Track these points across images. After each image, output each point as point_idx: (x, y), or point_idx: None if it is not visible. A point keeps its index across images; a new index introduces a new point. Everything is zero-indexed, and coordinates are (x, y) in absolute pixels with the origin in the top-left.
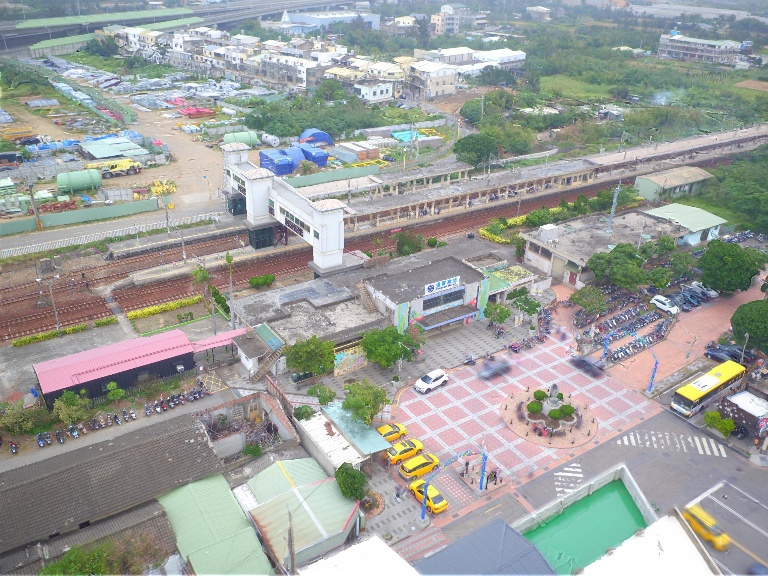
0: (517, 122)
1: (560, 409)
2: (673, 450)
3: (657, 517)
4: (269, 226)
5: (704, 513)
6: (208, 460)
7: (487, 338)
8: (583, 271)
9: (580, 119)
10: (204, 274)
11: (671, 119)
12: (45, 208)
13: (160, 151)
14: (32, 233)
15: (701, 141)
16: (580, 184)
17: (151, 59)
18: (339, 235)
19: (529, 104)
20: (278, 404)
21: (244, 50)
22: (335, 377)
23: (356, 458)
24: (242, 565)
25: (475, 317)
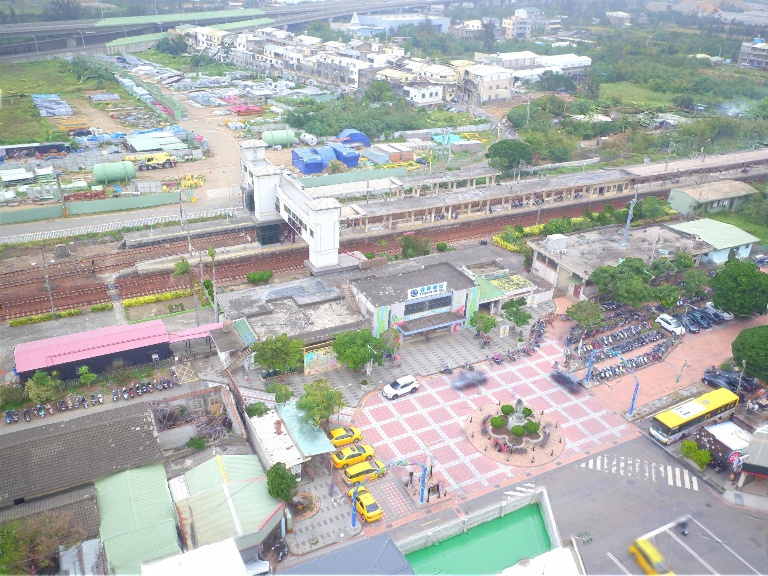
0: (565, 129)
1: (524, 426)
2: (640, 478)
3: None
4: (275, 223)
5: (656, 548)
6: (150, 449)
7: (472, 347)
8: (587, 284)
9: (630, 127)
10: (185, 266)
11: (725, 130)
12: (76, 196)
13: (197, 146)
14: (58, 220)
15: (756, 154)
16: (614, 194)
17: (216, 58)
18: (334, 235)
19: (582, 111)
20: (231, 399)
21: (301, 50)
22: (306, 376)
23: (296, 459)
24: (154, 555)
25: (464, 325)
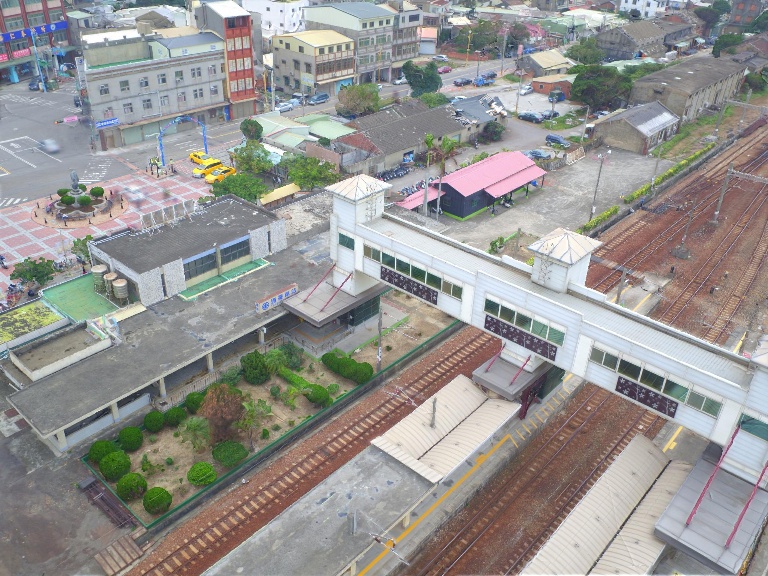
0: None
1: None
2: None
3: (84, 61)
4: None
5: None
6: None
7: None
8: None
9: None
10: None
11: None
12: None
13: None
14: None
15: None
16: None
17: None
18: None
19: None
20: None
21: None
22: None
23: None
24: None
25: None
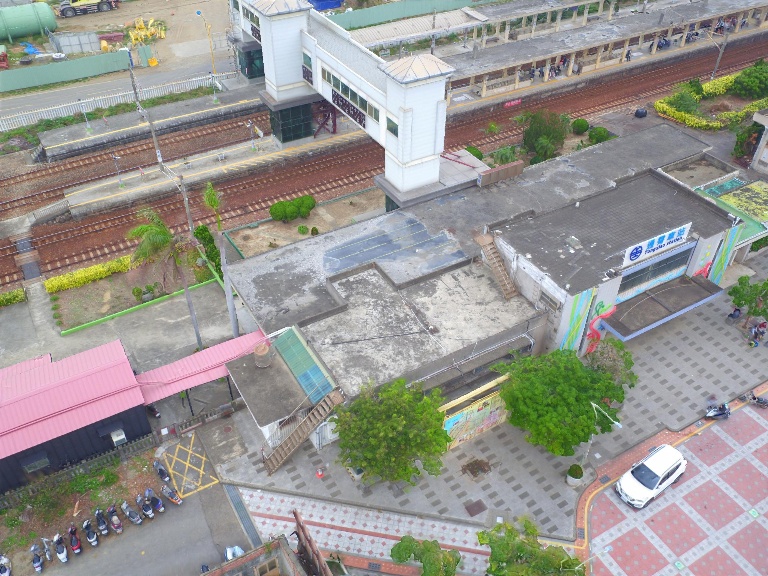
0: None
1: None
2: None
3: None
4: (304, 102)
5: None
6: None
7: (733, 345)
8: None
9: None
10: (158, 235)
11: None
12: None
13: None
14: None
15: None
16: None
17: None
18: (435, 128)
19: None
20: None
21: None
22: None
23: None
24: None
25: None
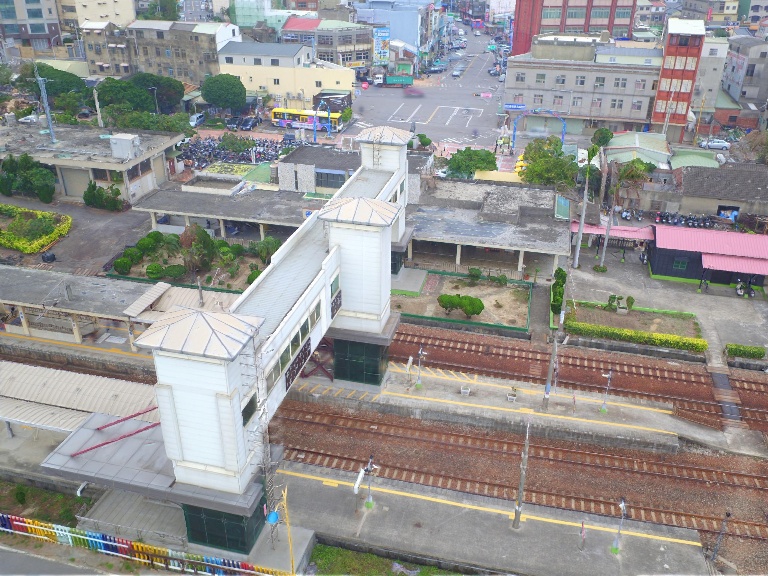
0: None
1: None
2: None
3: None
4: None
5: None
6: None
7: None
8: None
9: None
10: None
11: None
12: None
13: None
14: None
15: None
16: None
17: None
18: None
19: None
20: None
21: None
22: None
23: (582, 150)
24: None
25: None
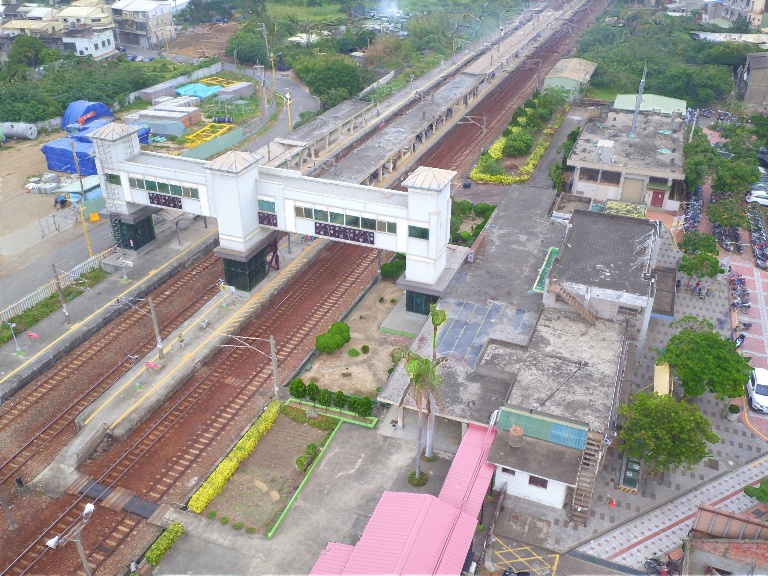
0: None
1: None
2: None
3: None
4: (263, 246)
5: None
6: None
7: (695, 303)
8: None
9: None
10: None
11: None
12: None
13: None
14: None
15: (518, 37)
16: (472, 101)
17: None
18: (446, 223)
19: (290, 32)
20: None
21: None
22: None
23: None
24: None
25: None
